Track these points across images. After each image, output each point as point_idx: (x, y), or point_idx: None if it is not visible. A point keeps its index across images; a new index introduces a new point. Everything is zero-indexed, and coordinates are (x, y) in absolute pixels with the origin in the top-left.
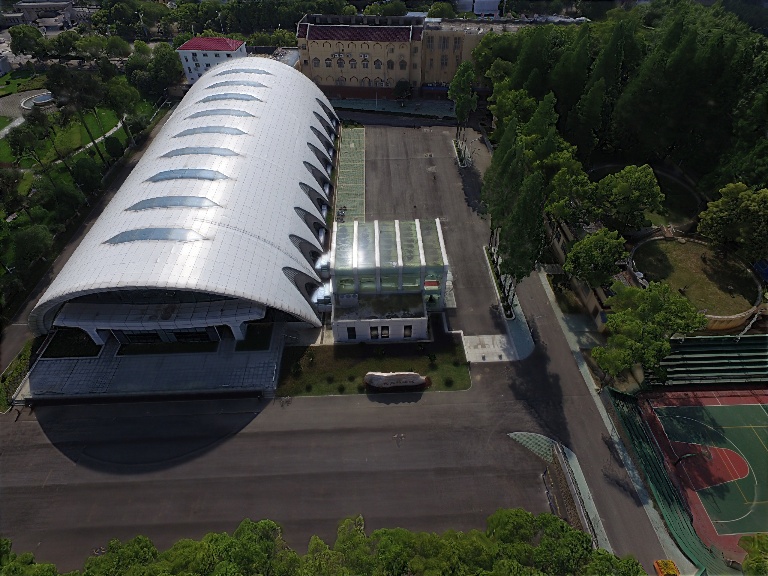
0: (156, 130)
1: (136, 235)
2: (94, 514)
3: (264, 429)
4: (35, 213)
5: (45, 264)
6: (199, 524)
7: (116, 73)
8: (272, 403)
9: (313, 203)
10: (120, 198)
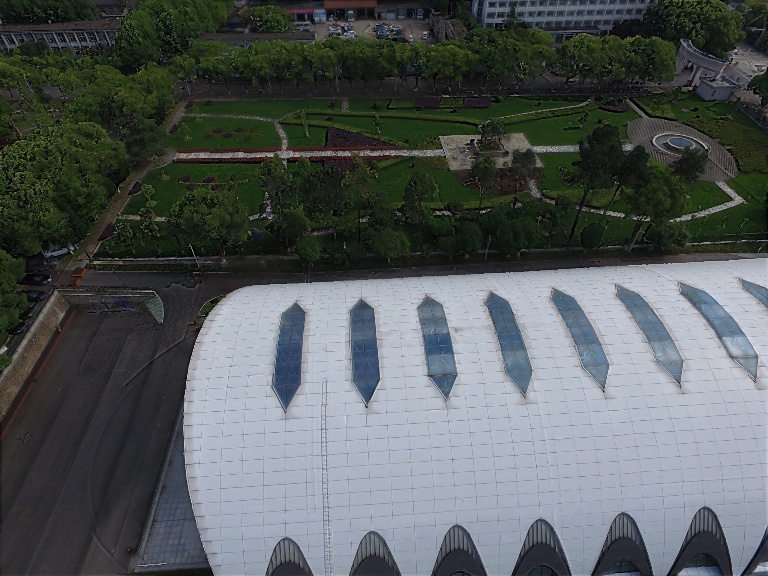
0: (684, 257)
1: (291, 328)
2: (65, 420)
3: (85, 568)
4: (442, 226)
5: (383, 264)
6: (3, 520)
7: (692, 173)
8: (120, 571)
9: (520, 559)
10: (405, 285)
